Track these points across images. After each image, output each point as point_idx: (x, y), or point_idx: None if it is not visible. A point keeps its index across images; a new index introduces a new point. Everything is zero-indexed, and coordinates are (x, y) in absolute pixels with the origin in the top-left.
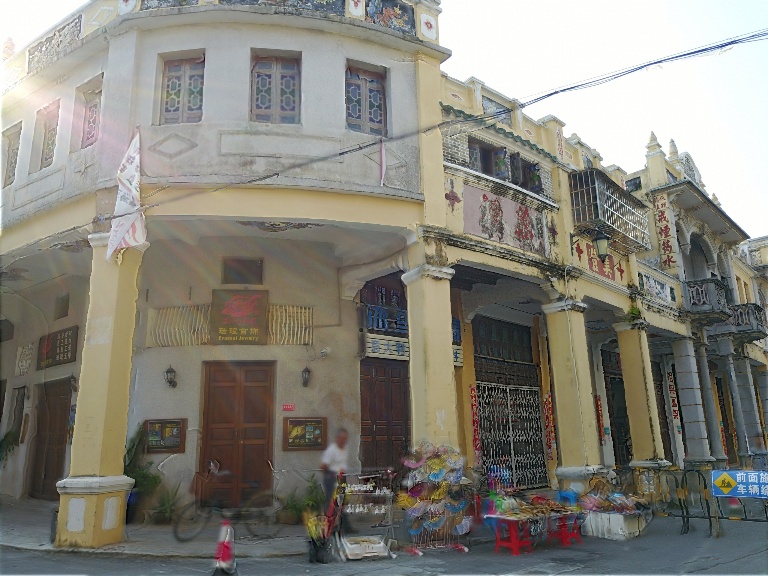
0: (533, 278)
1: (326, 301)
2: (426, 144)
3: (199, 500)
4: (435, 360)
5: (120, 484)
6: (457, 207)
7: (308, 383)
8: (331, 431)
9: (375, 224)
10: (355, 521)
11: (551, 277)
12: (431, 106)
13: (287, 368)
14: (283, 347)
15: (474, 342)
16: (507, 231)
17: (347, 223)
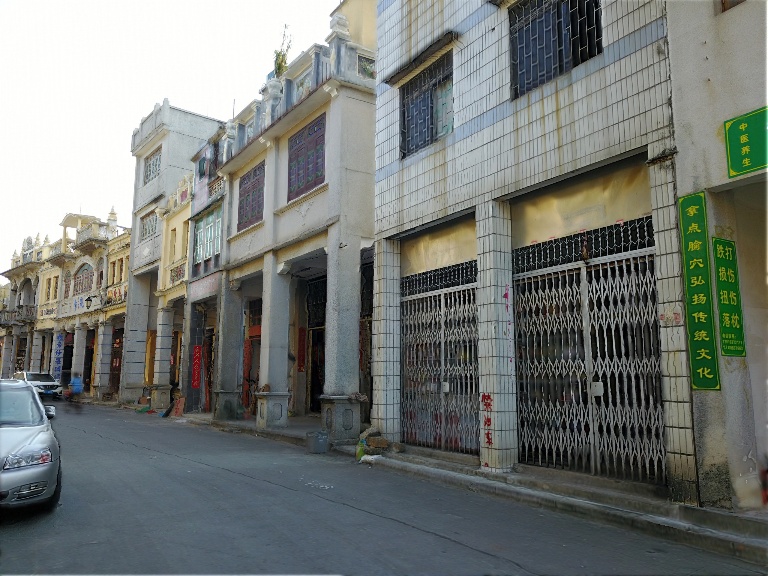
0: None
1: None
2: None
3: None
4: None
5: None
6: None
7: None
8: None
9: None
10: None
11: None
12: None
13: None
14: None
15: (21, 346)
16: None
17: None
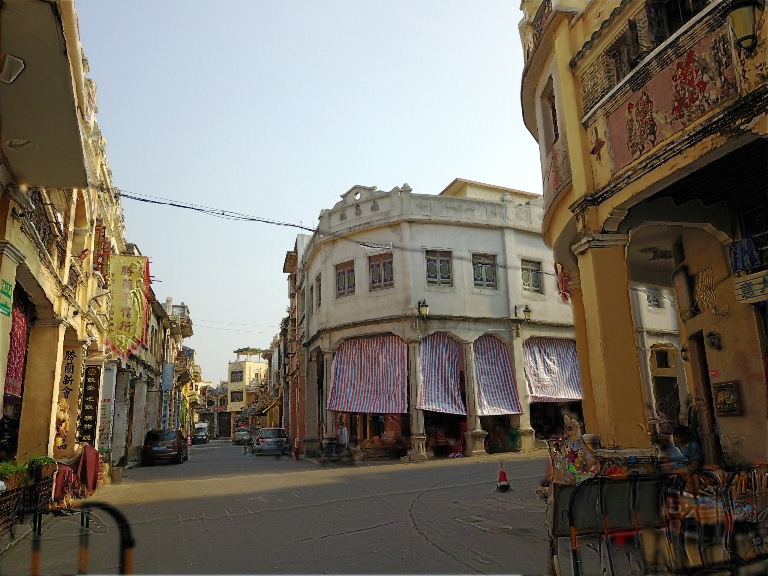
0: (717, 151)
1: (715, 254)
2: (567, 121)
3: (712, 458)
4: (591, 335)
5: (596, 439)
6: (603, 153)
7: (721, 346)
8: (743, 395)
9: (567, 224)
10: (559, 475)
11: (748, 122)
12: (565, 76)
13: (706, 335)
14: (703, 314)
15: None
16: (661, 122)
17: (561, 234)
